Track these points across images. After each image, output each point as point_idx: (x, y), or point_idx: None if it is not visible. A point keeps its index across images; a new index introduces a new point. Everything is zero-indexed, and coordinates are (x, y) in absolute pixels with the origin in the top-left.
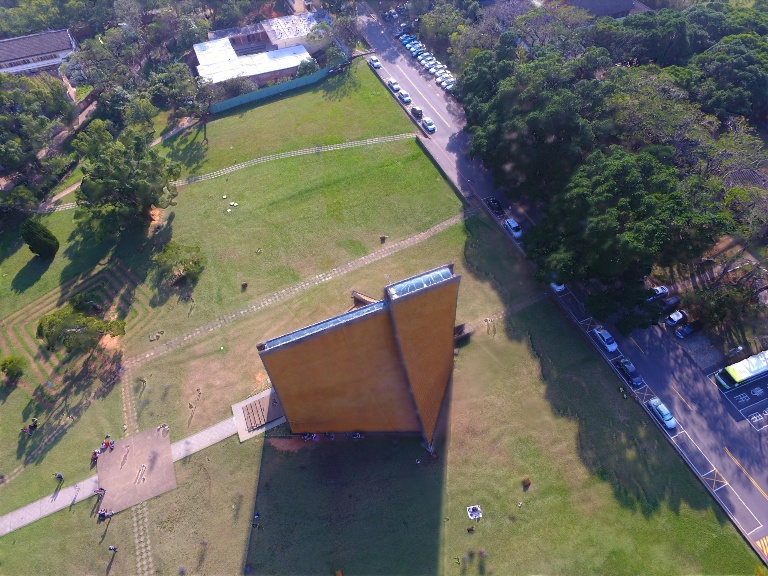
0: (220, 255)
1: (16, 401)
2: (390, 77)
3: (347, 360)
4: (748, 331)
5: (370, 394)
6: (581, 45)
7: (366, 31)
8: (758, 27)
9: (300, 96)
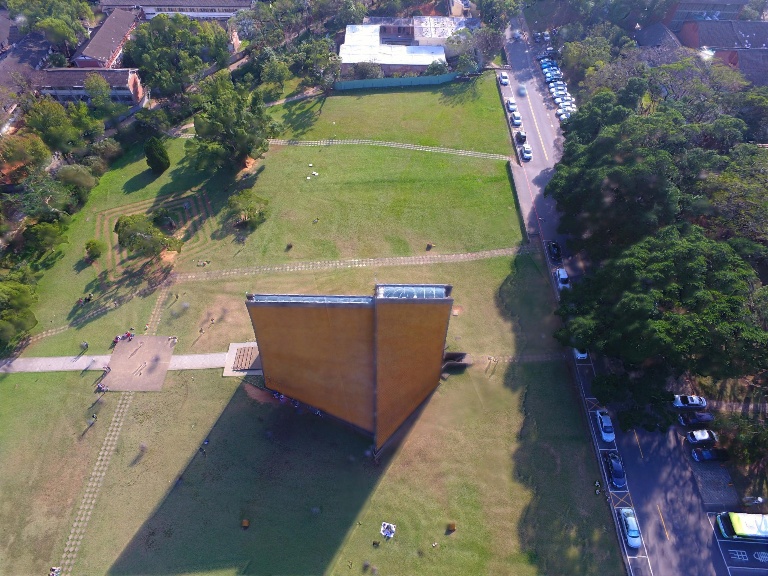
0: (283, 214)
1: (86, 276)
2: (512, 96)
3: (326, 340)
4: None
5: (340, 380)
6: (718, 111)
7: (511, 47)
8: None
9: (419, 93)
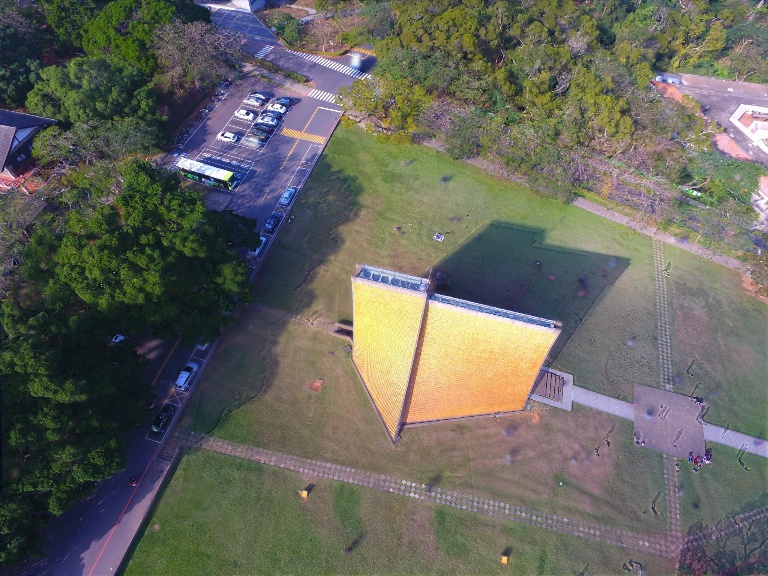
0: None
1: None
2: None
3: None
4: None
5: None
6: None
7: None
8: None
9: None
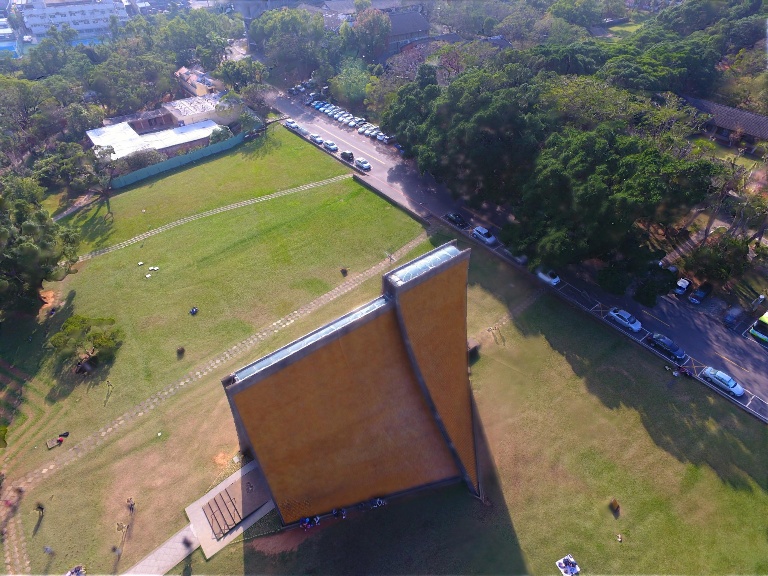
0: (142, 324)
1: None
2: (310, 134)
3: (349, 390)
4: (754, 285)
5: (385, 436)
6: (496, 68)
7: (276, 104)
8: (629, 54)
9: (217, 161)
